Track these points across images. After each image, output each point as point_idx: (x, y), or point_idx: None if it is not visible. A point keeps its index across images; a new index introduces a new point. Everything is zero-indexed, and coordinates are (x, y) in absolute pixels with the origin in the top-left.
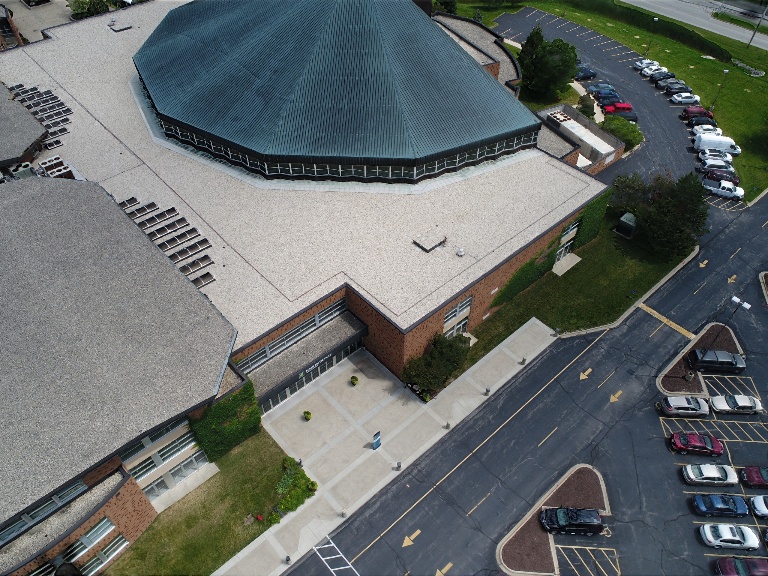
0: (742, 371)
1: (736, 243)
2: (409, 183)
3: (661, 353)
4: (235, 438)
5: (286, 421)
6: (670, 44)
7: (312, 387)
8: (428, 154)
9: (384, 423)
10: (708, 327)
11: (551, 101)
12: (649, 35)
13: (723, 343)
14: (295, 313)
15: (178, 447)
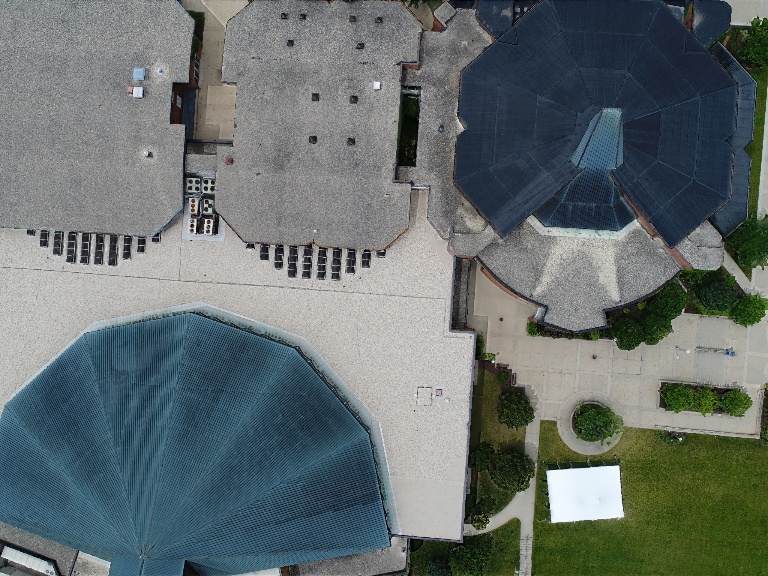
0: None
1: None
2: None
3: None
4: None
5: None
6: None
7: None
8: (2, 415)
9: None
10: None
11: None
12: None
13: None
14: None
15: None
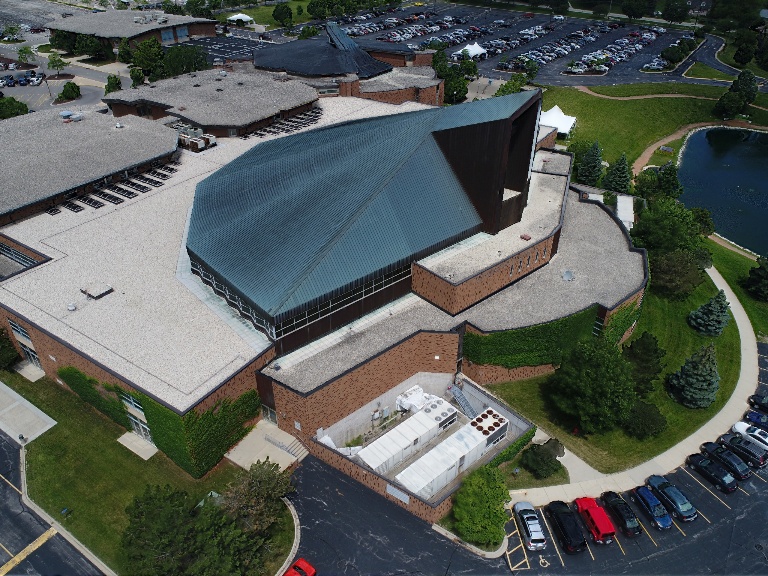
0: None
1: None
2: None
3: None
4: None
5: None
6: None
7: None
8: (194, 250)
9: None
10: None
11: (566, 424)
12: None
13: None
14: (25, 244)
15: None
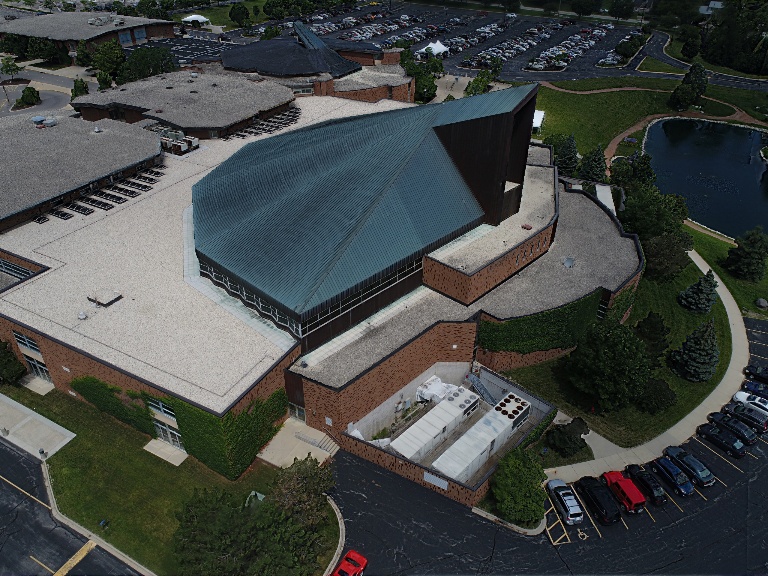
0: None
1: None
2: None
3: None
4: None
5: None
6: None
7: None
8: (204, 253)
9: None
10: None
11: (583, 404)
12: None
13: None
14: (17, 254)
15: None
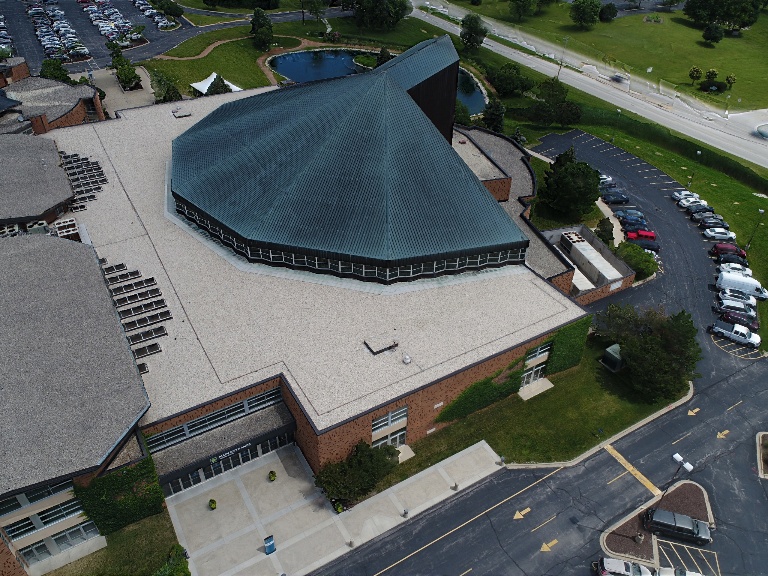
0: (706, 543)
1: (738, 394)
2: (382, 283)
3: (615, 505)
4: (131, 514)
5: (191, 506)
6: (720, 178)
7: (230, 475)
8: (402, 257)
9: (287, 527)
10: (678, 484)
11: (572, 221)
12: (700, 167)
13: (691, 506)
14: (220, 396)
15: (62, 513)
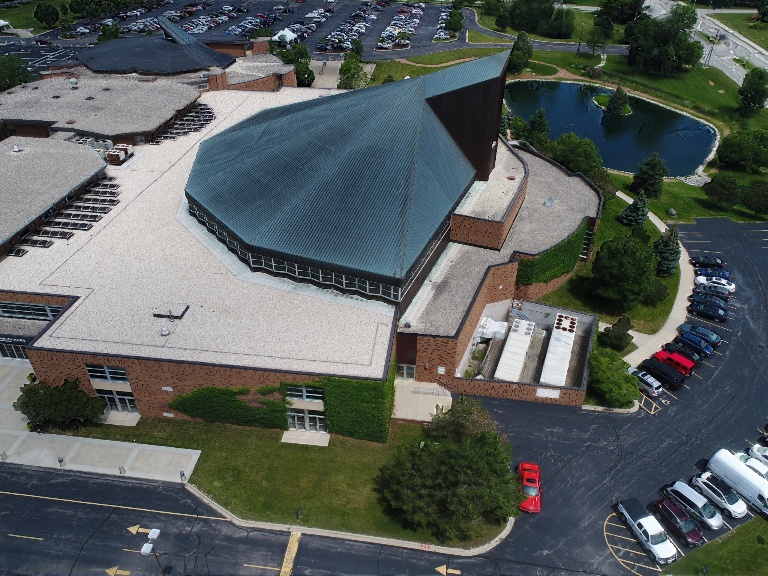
0: None
1: None
2: None
3: None
4: None
5: None
6: None
7: (19, 362)
8: (261, 246)
9: None
10: None
11: (606, 311)
12: None
13: None
14: (25, 291)
15: None
